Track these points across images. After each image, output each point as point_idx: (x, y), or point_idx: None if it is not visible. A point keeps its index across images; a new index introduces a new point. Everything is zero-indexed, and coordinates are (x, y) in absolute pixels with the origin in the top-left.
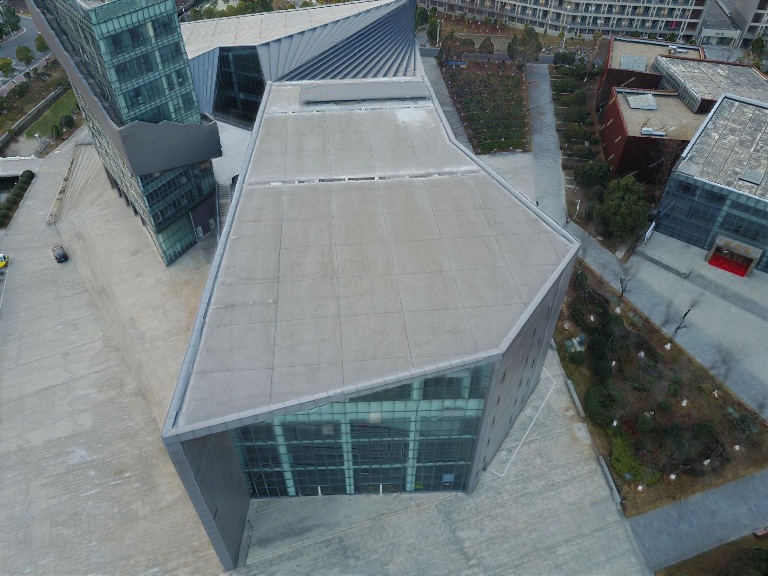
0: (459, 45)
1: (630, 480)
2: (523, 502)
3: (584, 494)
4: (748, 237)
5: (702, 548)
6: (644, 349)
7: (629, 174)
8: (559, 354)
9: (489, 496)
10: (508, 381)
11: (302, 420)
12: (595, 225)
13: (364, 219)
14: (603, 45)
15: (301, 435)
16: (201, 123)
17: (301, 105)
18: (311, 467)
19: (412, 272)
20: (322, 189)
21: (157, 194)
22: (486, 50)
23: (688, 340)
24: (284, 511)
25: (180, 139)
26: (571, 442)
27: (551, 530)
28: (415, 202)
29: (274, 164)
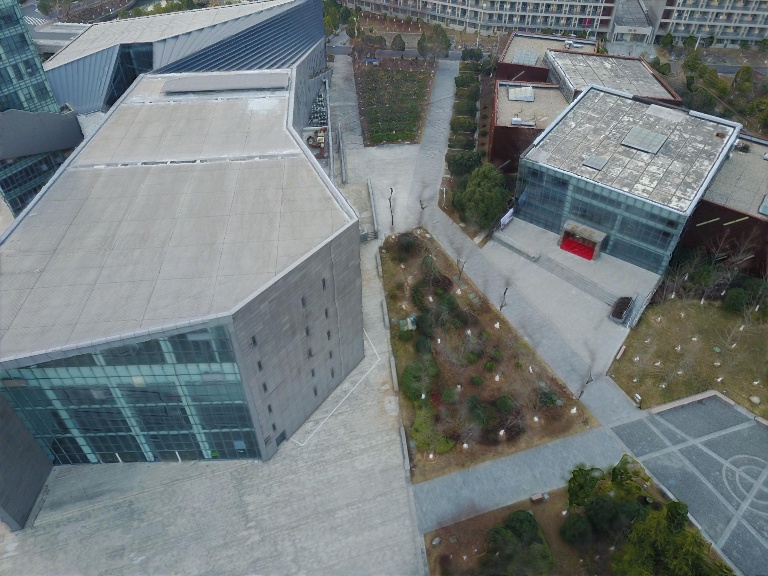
0: (371, 42)
1: (423, 449)
2: (316, 469)
3: (377, 462)
4: (593, 221)
5: (477, 512)
6: (473, 328)
7: (503, 164)
8: (391, 333)
9: (284, 464)
10: (272, 348)
11: (71, 384)
12: (459, 212)
13: (165, 198)
14: (503, 41)
15: (75, 399)
16: (59, 113)
17: (160, 95)
18: (101, 433)
19: (185, 245)
20: (139, 171)
21: (13, 180)
22: (397, 47)
23: (521, 320)
24: (83, 477)
25: (32, 127)
26: (378, 414)
27: (336, 495)
28: (222, 182)
29: (106, 149)
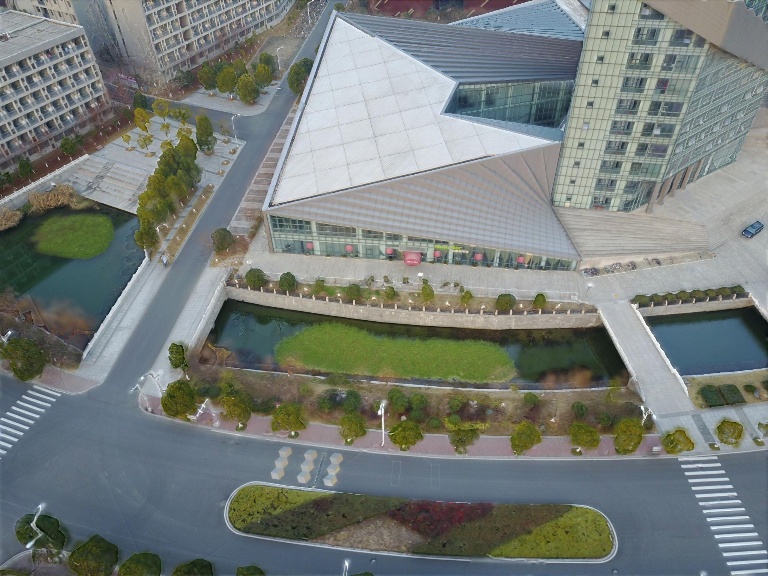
0: None
1: None
2: None
3: None
4: None
5: None
6: None
7: None
8: None
9: None
10: None
11: None
12: None
13: None
14: None
15: None
16: None
17: None
18: None
19: None
20: None
21: None
22: None
23: None
24: None
25: None
26: None
27: None
28: None
29: None
